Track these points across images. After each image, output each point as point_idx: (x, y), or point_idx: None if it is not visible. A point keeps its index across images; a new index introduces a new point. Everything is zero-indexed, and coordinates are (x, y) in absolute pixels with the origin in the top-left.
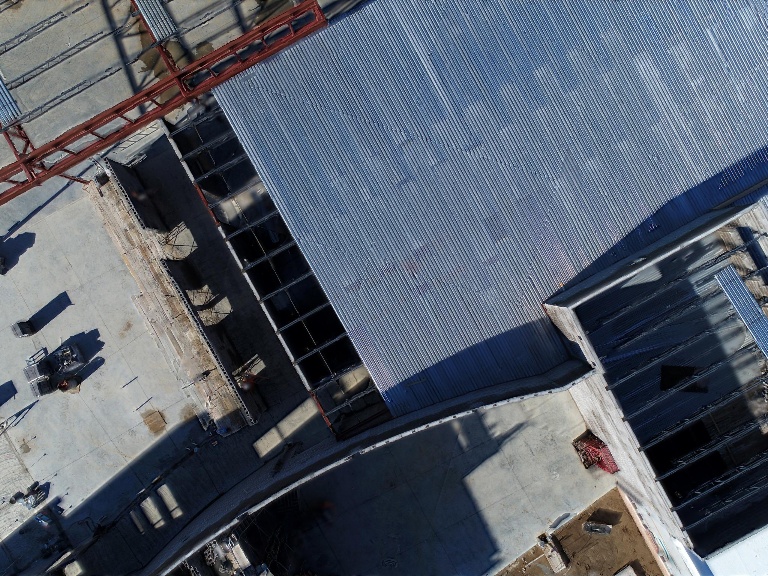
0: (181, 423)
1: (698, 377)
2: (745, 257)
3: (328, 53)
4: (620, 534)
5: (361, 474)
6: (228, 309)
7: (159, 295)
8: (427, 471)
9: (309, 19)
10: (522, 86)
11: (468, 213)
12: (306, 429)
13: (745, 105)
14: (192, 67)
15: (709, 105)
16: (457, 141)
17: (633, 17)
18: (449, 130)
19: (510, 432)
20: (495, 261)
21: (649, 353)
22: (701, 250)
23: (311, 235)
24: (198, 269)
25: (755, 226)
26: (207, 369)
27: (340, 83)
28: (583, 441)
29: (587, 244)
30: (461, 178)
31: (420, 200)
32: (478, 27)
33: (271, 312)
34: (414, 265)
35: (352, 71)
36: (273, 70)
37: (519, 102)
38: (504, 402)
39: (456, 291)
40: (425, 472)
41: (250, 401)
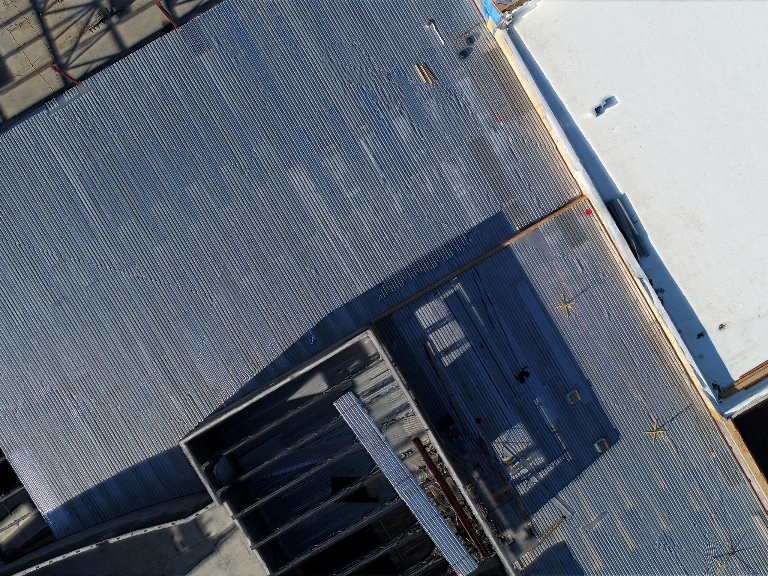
0: None
1: (323, 504)
2: None
3: None
4: None
5: None
6: None
7: None
8: (143, 573)
9: (5, 125)
10: (174, 203)
11: (124, 332)
12: (20, 535)
13: (403, 215)
14: None
15: (366, 216)
16: (110, 261)
17: (285, 130)
18: (101, 250)
19: (225, 532)
20: (154, 379)
21: None
22: (366, 360)
23: None
24: None
25: None
26: None
27: None
28: None
29: (247, 359)
30: (116, 298)
31: (75, 321)
32: (127, 146)
33: None
34: (72, 386)
35: None
36: None
37: (172, 220)
38: (128, 535)
39: (116, 411)
40: (142, 574)
41: None
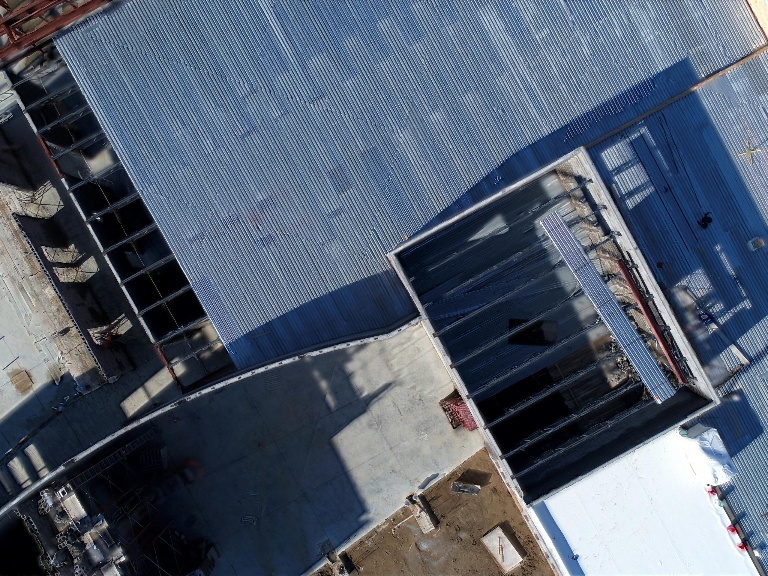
0: (48, 383)
1: (525, 324)
2: (584, 208)
3: (171, 5)
4: (490, 495)
5: (229, 434)
6: (95, 268)
7: (10, 249)
8: (295, 431)
9: None
10: (366, 38)
11: (312, 165)
12: (173, 389)
13: (590, 58)
14: (18, 13)
15: (554, 58)
16: (301, 93)
17: None
18: (293, 82)
19: (378, 392)
20: (339, 213)
21: (497, 306)
22: None
23: (154, 187)
24: (64, 228)
25: (583, 173)
26: (67, 326)
27: (183, 35)
28: (448, 400)
29: (432, 196)
30: (305, 130)
31: (264, 152)
32: None
33: (116, 264)
34: (258, 217)
35: (195, 23)
36: (115, 22)
37: (363, 54)
38: (330, 348)
39: (300, 243)
40: (293, 432)
41: (108, 358)
